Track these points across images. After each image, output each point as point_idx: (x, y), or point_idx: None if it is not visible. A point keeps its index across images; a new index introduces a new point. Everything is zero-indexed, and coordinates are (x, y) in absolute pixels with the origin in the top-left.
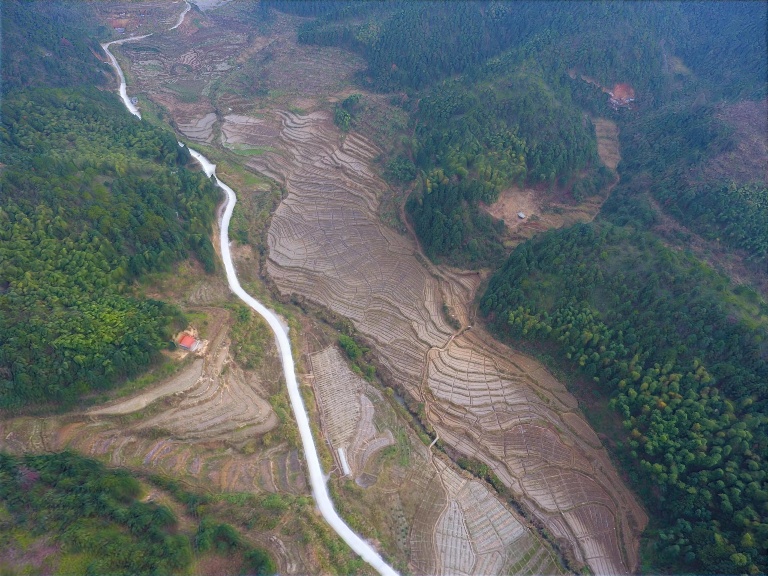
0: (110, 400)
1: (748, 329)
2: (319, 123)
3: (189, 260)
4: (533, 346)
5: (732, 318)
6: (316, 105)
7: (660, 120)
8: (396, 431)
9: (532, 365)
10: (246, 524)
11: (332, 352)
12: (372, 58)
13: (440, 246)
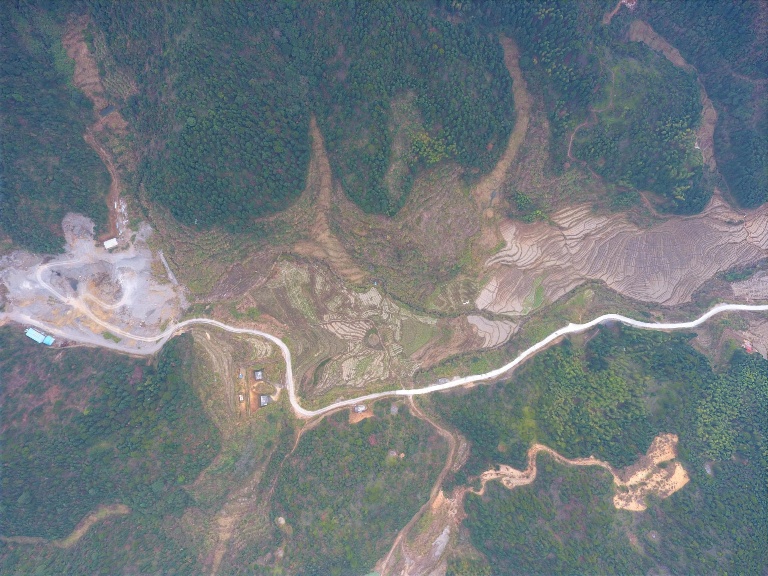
0: None
1: None
2: (519, 235)
3: None
4: None
5: None
6: (493, 230)
7: (685, 6)
8: None
9: None
10: None
11: (735, 286)
12: (460, 159)
13: None
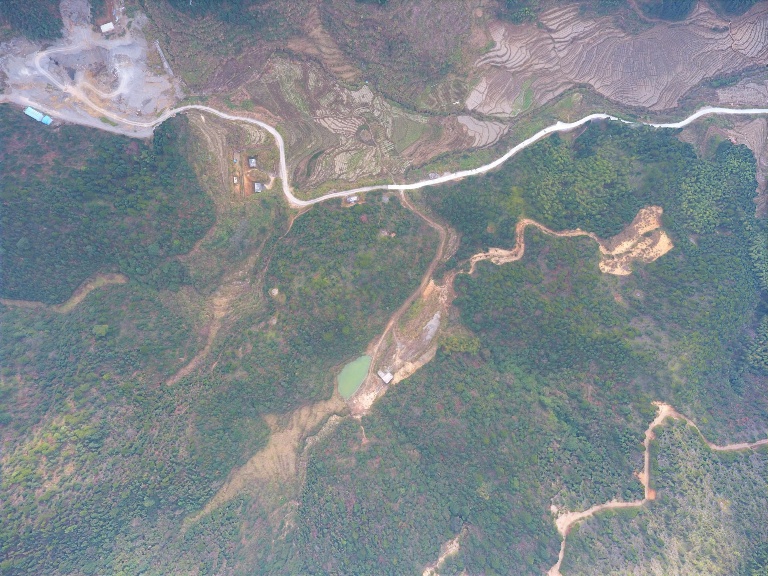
0: None
1: None
2: (508, 36)
3: None
4: None
5: None
6: (482, 30)
7: None
8: (766, 78)
9: (757, 7)
10: None
11: (720, 92)
12: None
13: None
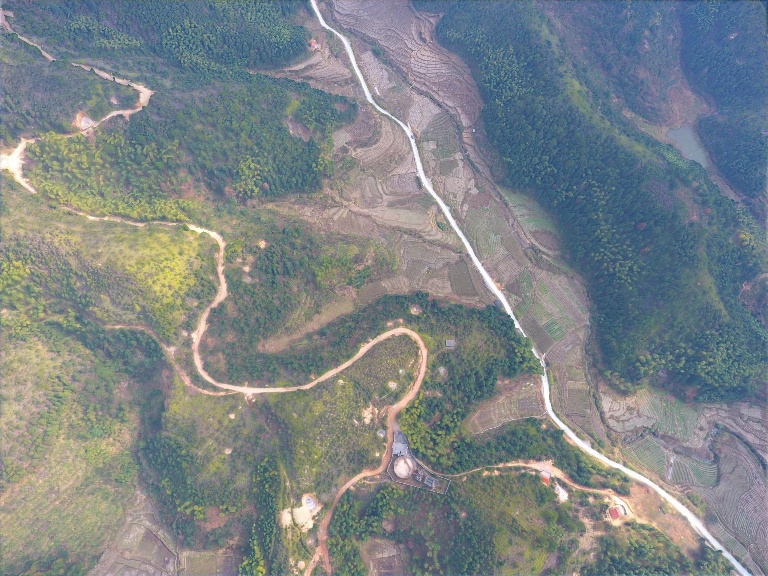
0: (292, 65)
1: (532, 31)
2: None
3: (302, 9)
4: (457, 48)
5: (529, 27)
6: None
7: None
8: (397, 82)
9: (456, 57)
10: None
11: (370, 53)
12: None
13: (420, 0)
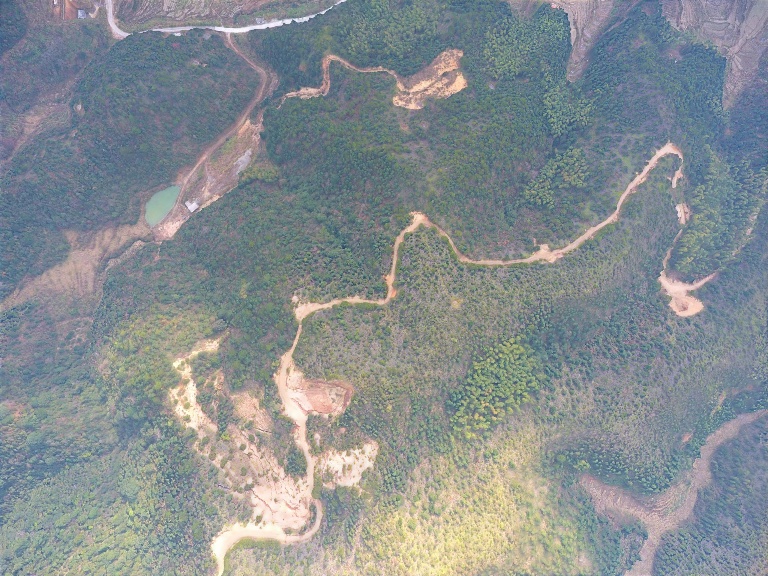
0: None
1: None
2: None
3: None
4: None
5: None
6: None
7: None
8: None
9: None
10: (629, 5)
11: None
12: None
13: None
